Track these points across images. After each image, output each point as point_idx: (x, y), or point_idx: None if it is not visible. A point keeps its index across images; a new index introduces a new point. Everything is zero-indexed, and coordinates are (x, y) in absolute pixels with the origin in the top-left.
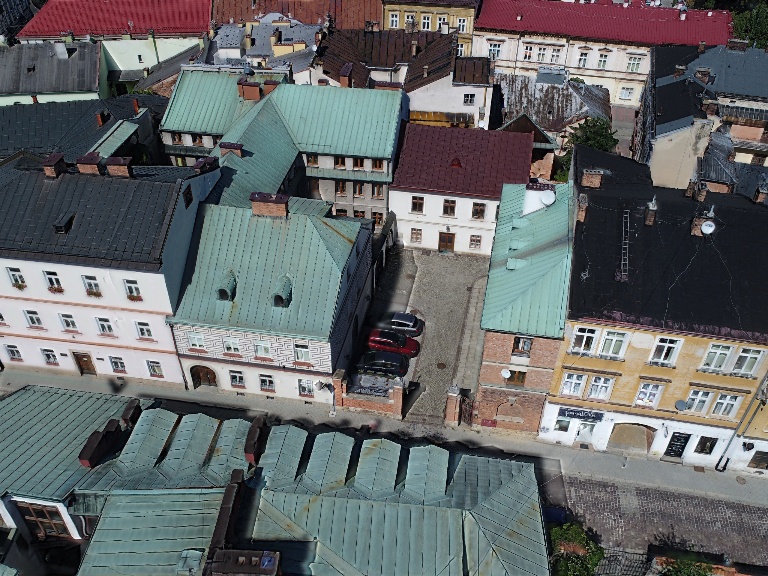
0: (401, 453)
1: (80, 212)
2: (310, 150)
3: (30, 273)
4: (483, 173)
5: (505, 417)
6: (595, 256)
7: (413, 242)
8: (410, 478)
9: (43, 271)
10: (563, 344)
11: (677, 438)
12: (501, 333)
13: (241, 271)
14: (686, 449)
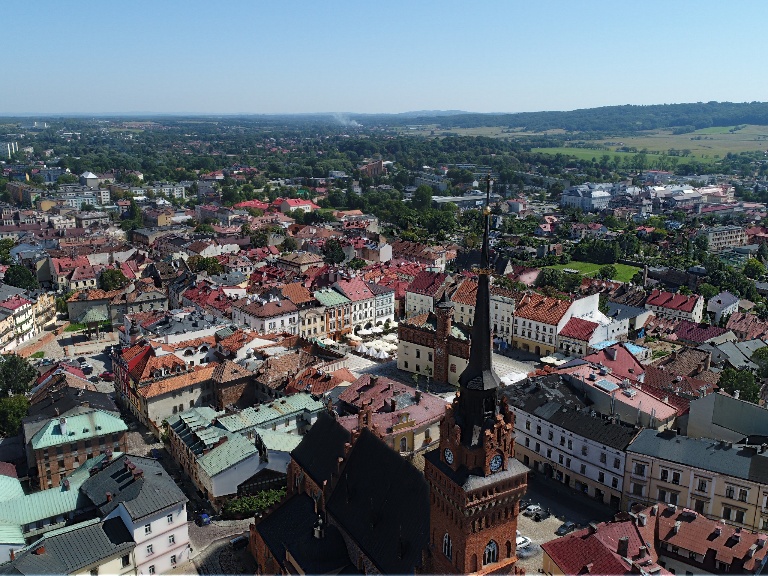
0: None
1: None
2: None
3: None
4: (4, 472)
5: None
6: None
7: None
8: (191, 416)
9: None
10: None
11: None
12: None
13: None
14: None
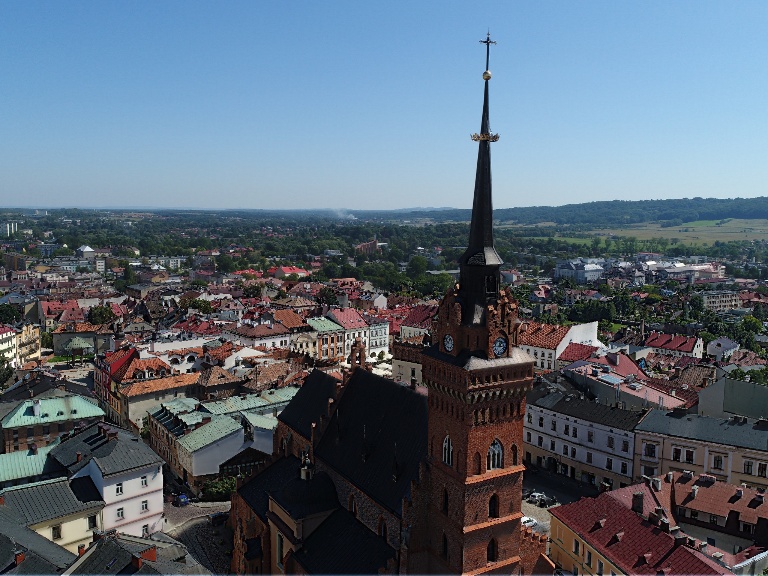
0: None
1: None
2: None
3: None
4: None
5: None
6: None
7: None
8: None
9: None
10: None
11: None
12: None
13: None
14: None
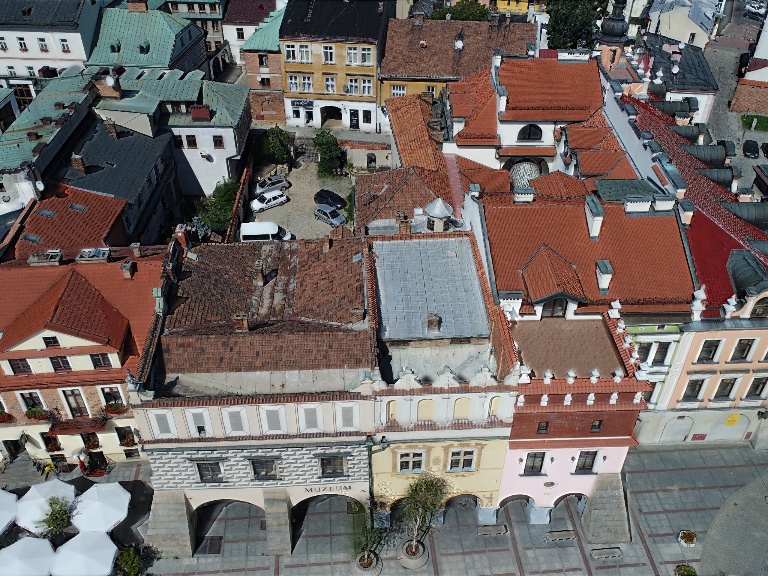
0: (184, 74)
1: (35, 6)
2: (173, 0)
3: (10, 39)
4: None
5: (267, 112)
6: (296, 13)
7: (242, 61)
8: None
9: (17, 38)
10: (282, 56)
11: (353, 114)
12: (251, 53)
13: (123, 39)
14: (359, 121)
